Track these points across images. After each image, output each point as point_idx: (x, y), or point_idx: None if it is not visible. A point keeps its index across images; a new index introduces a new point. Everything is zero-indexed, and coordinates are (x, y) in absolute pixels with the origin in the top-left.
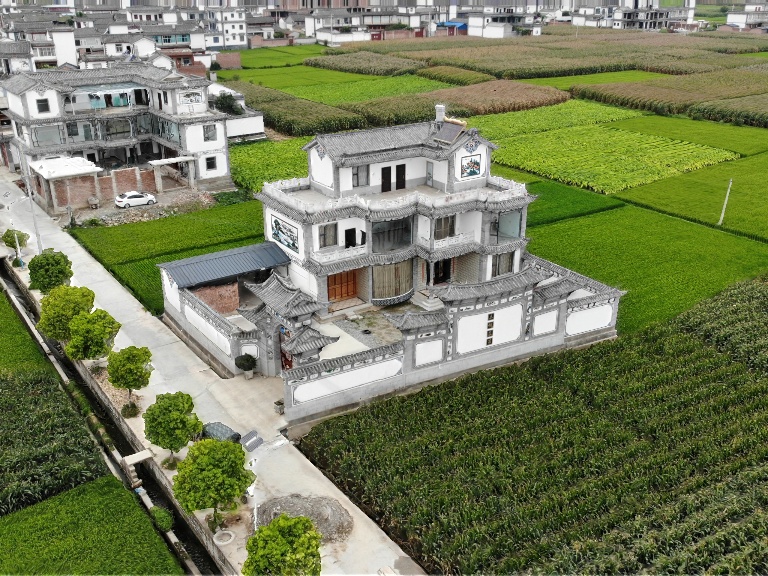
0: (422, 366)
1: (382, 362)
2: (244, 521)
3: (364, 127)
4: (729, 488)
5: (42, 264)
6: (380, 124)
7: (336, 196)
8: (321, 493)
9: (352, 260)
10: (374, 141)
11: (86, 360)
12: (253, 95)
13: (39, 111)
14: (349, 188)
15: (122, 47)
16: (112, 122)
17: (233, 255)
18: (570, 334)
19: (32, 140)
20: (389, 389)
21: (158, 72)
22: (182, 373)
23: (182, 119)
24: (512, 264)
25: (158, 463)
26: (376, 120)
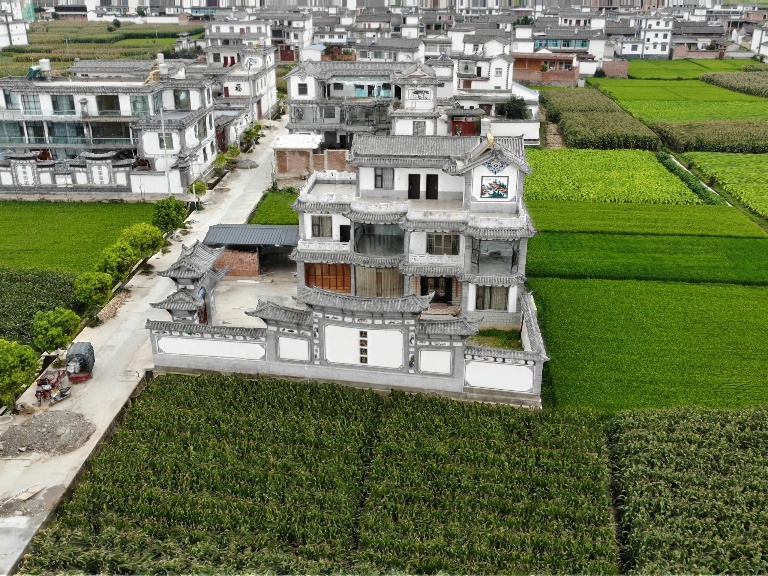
0: (287, 360)
1: (244, 342)
2: (31, 416)
3: (654, 148)
4: (335, 571)
5: (158, 206)
6: (677, 148)
7: (356, 193)
8: (96, 421)
9: (331, 254)
10: (411, 147)
11: (130, 283)
12: (577, 103)
13: (299, 93)
14: (370, 188)
15: (479, 47)
16: (371, 110)
17: (268, 229)
18: (473, 385)
19: (291, 117)
20: (252, 371)
21: (412, 69)
22: (163, 310)
23: (393, 112)
24: (507, 302)
25: (54, 361)
26: (675, 143)
